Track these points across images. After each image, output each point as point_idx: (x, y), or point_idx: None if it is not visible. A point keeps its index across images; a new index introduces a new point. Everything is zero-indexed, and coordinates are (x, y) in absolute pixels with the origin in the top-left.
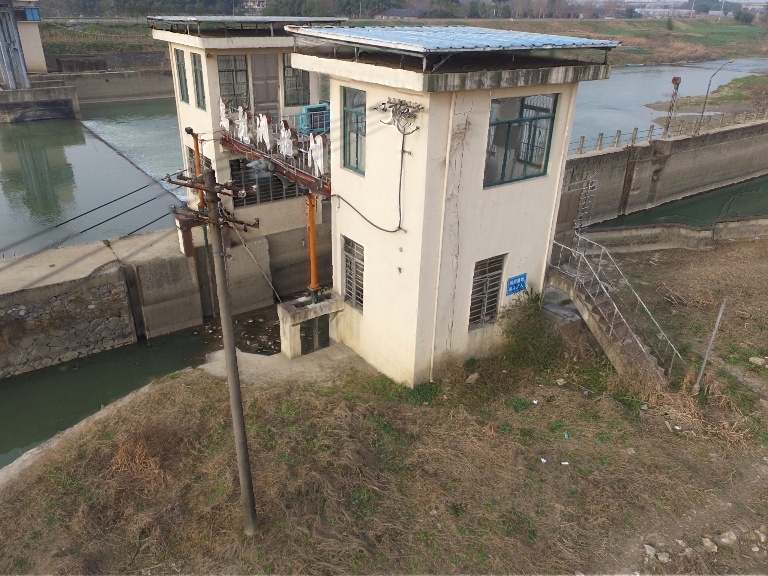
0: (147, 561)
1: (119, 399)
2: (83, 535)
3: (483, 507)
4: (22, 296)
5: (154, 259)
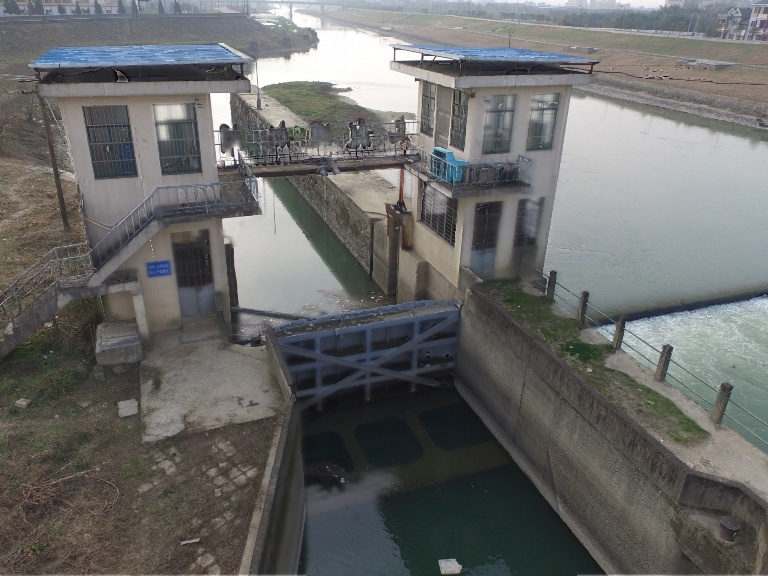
0: None
1: None
2: None
3: (1, 269)
4: None
5: (385, 225)
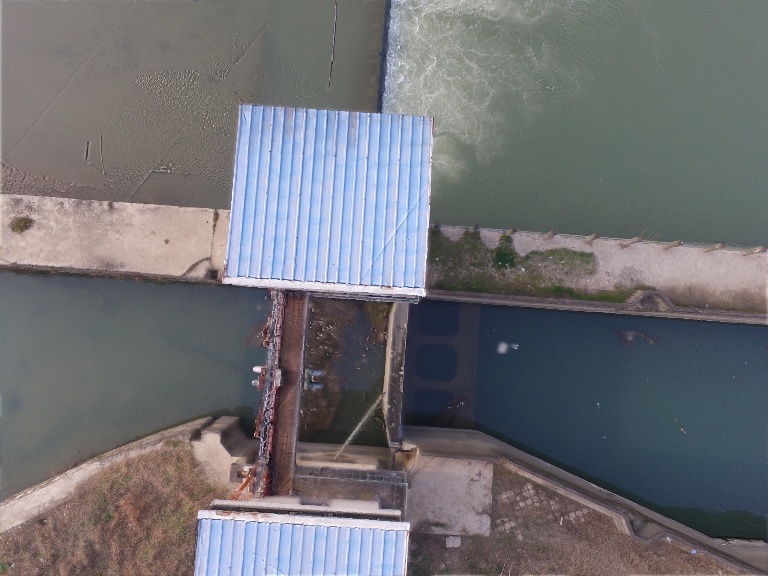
0: (112, 567)
1: (144, 447)
2: (96, 539)
3: None
4: (139, 274)
5: None
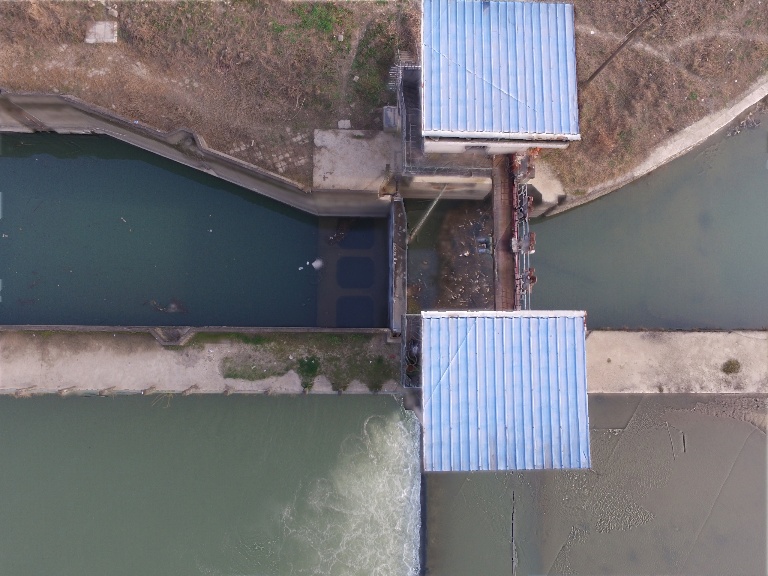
0: None
1: None
2: None
3: None
4: None
5: None
